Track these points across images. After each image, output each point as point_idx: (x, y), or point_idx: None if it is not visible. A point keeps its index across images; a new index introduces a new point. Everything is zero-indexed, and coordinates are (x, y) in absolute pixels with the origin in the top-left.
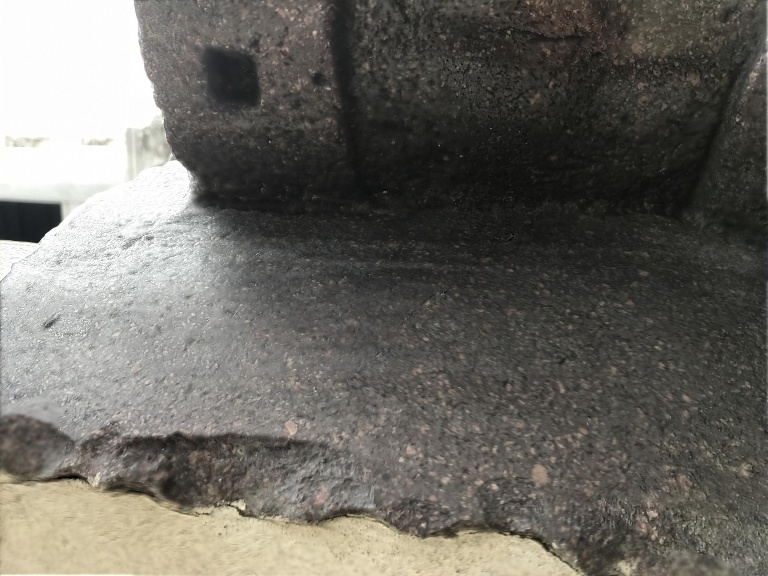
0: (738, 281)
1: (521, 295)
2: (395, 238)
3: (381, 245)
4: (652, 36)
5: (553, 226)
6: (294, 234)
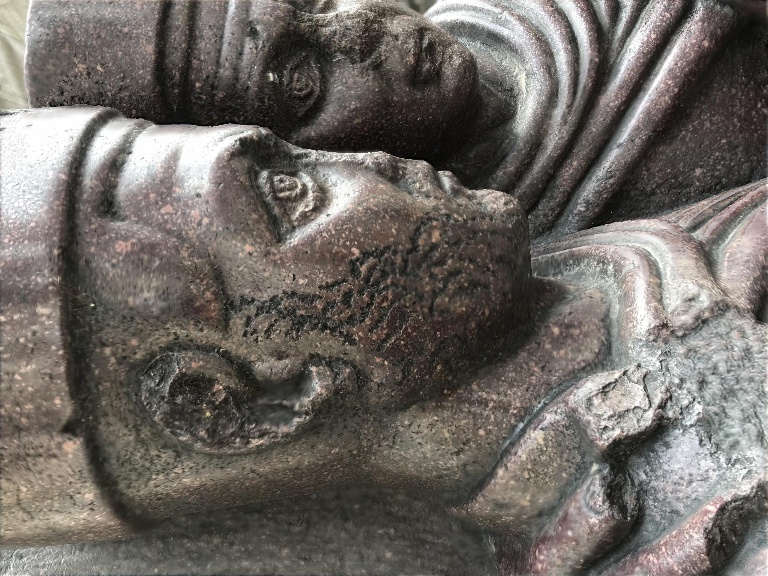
0: (444, 557)
1: None
2: (217, 530)
3: (208, 542)
4: (389, 474)
5: (332, 501)
6: (138, 539)
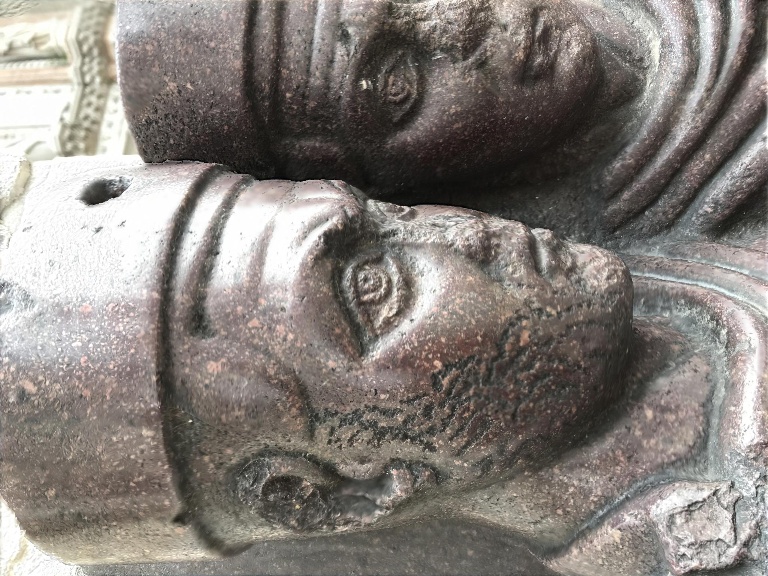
0: (523, 561)
1: (397, 574)
2: None
3: None
4: None
5: None
6: None
